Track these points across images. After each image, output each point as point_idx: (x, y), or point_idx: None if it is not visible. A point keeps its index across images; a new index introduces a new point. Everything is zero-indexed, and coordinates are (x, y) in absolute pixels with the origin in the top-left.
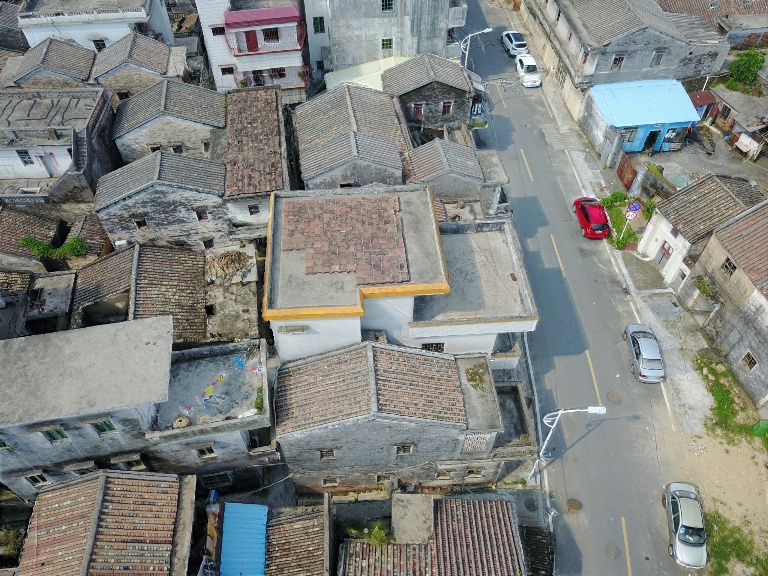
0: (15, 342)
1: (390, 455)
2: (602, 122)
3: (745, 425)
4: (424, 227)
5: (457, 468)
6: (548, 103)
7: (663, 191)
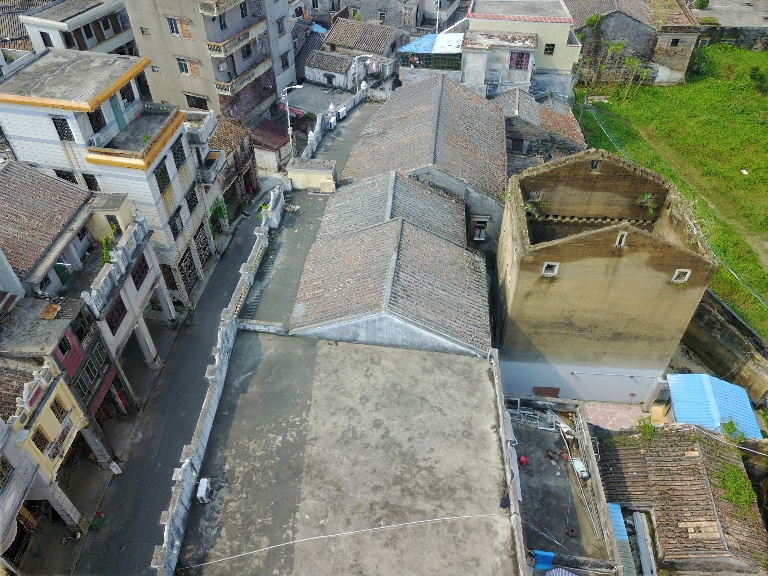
0: None
1: None
2: None
3: None
4: None
5: None
6: None
7: None
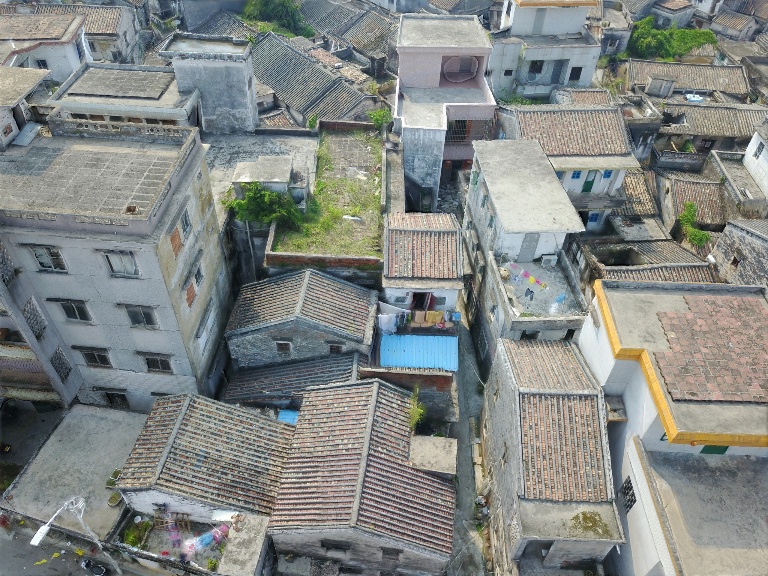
0: (545, 161)
1: None
2: None
3: None
4: None
5: None
6: None
7: None
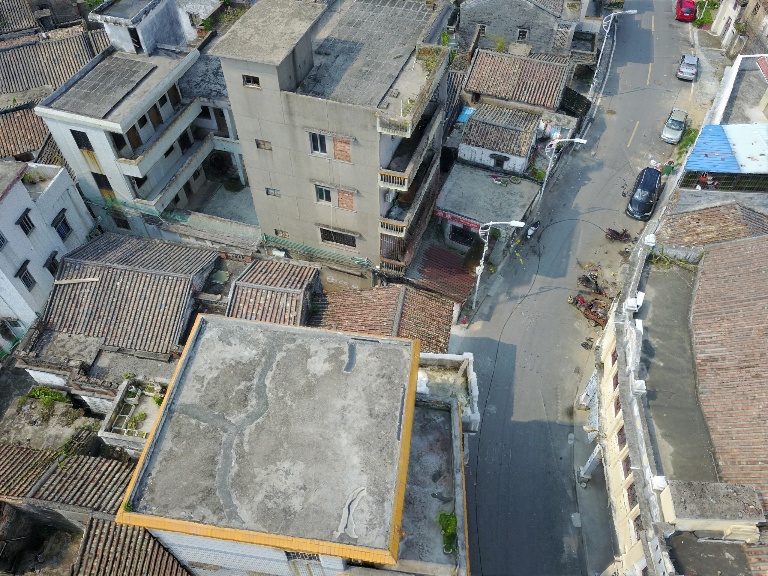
0: None
1: (514, 39)
2: None
3: None
4: None
5: None
6: None
7: None
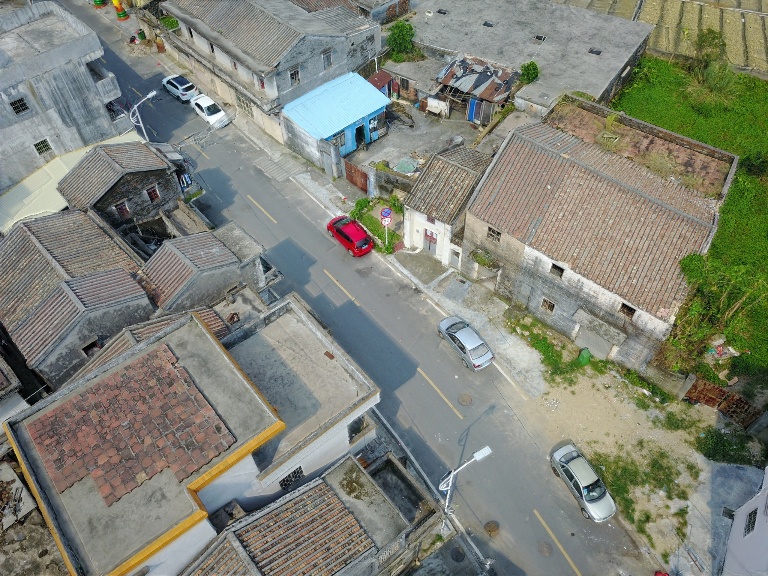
0: None
1: None
2: (310, 139)
3: (572, 361)
4: (216, 365)
5: None
6: (247, 137)
7: (399, 183)
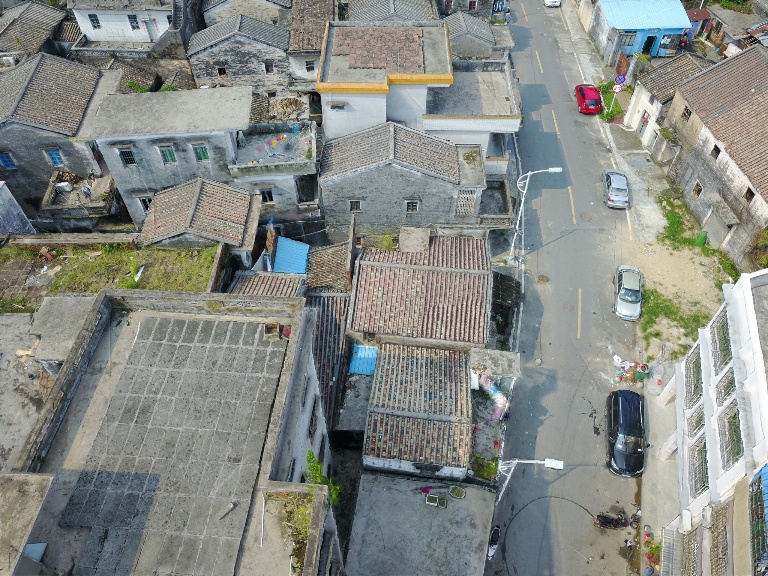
0: (143, 94)
1: (402, 212)
2: (606, 26)
3: (689, 238)
4: (439, 47)
5: (452, 235)
6: (565, 19)
7: None
